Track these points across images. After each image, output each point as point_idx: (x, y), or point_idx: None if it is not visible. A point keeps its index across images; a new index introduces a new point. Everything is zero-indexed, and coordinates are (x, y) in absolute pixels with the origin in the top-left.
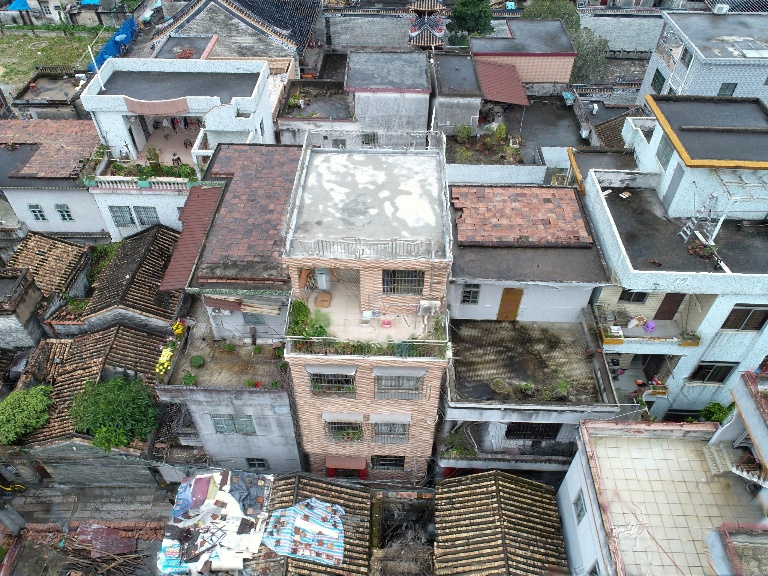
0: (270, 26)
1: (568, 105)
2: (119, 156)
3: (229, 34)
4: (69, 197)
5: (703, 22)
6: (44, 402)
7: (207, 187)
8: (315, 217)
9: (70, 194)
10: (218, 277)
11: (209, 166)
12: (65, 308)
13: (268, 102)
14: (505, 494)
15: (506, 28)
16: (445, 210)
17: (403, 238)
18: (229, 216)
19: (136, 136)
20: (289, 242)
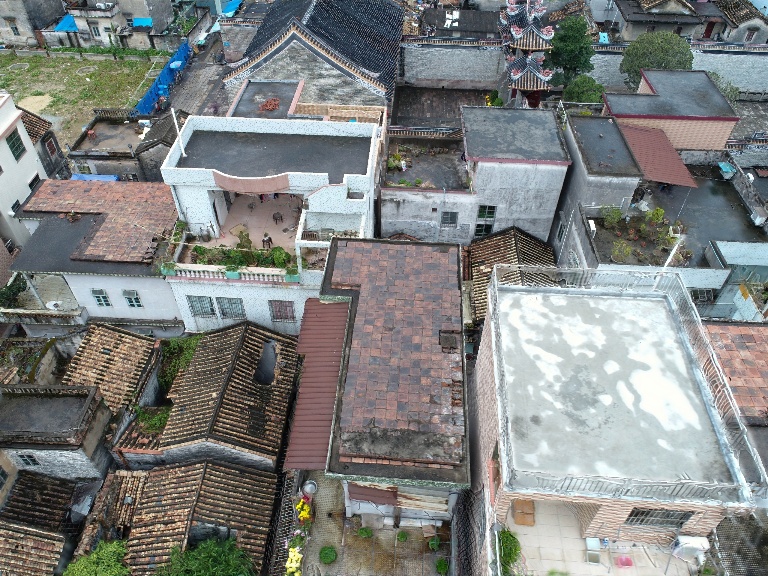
0: (358, 68)
1: (726, 178)
2: (198, 233)
3: (311, 75)
4: (140, 283)
5: None
6: (119, 575)
7: (326, 302)
8: (528, 409)
9: (142, 280)
10: (366, 456)
11: (326, 272)
12: (135, 424)
13: (373, 170)
14: None
15: (601, 63)
16: (713, 405)
17: (697, 482)
18: (365, 353)
19: (219, 210)
20: (506, 460)
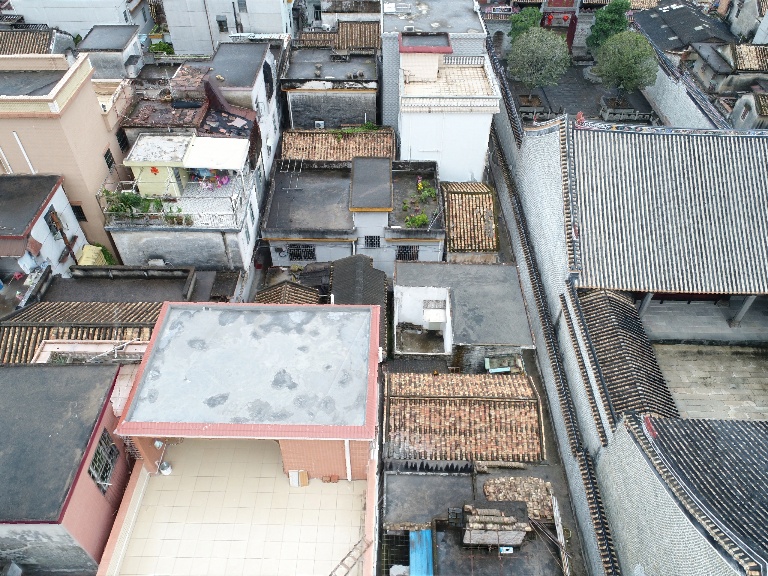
0: None
1: None
2: None
3: None
4: None
5: (455, 4)
6: None
7: None
8: None
9: None
10: None
11: None
12: None
13: None
14: (151, 8)
15: None
16: None
17: None
18: None
19: None
20: None
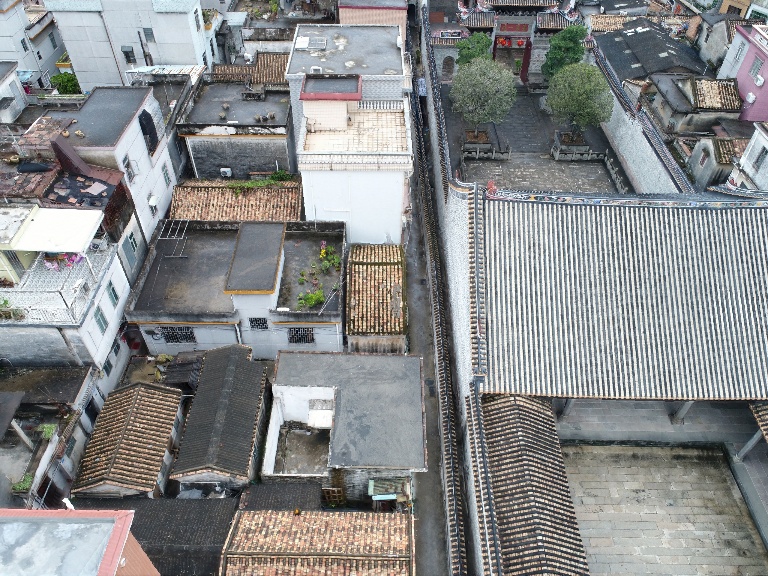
0: None
1: None
2: None
3: None
4: None
5: (378, 37)
6: None
7: None
8: None
9: None
10: None
11: None
12: None
13: None
14: None
15: None
16: None
17: None
18: None
19: None
20: None
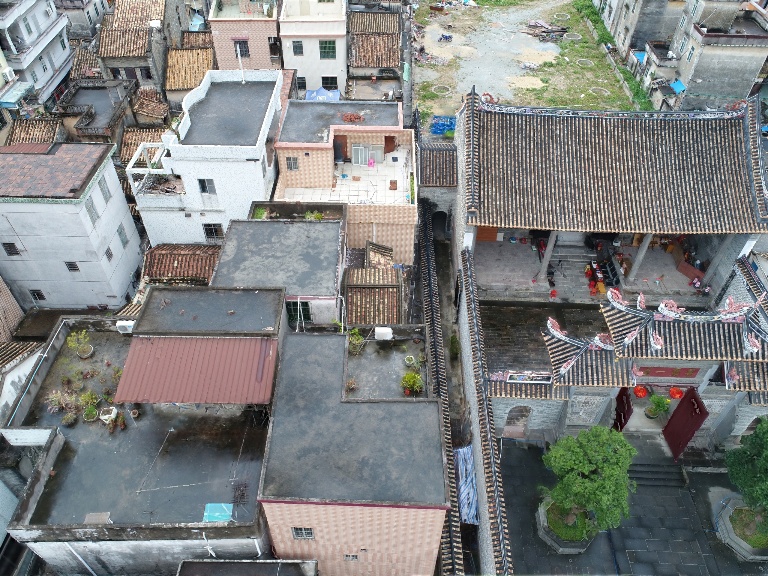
0: None
1: None
2: None
3: None
4: None
5: None
6: None
7: None
8: None
9: None
10: None
11: None
12: None
13: (250, 181)
14: None
15: None
16: None
17: None
18: None
19: None
20: None
